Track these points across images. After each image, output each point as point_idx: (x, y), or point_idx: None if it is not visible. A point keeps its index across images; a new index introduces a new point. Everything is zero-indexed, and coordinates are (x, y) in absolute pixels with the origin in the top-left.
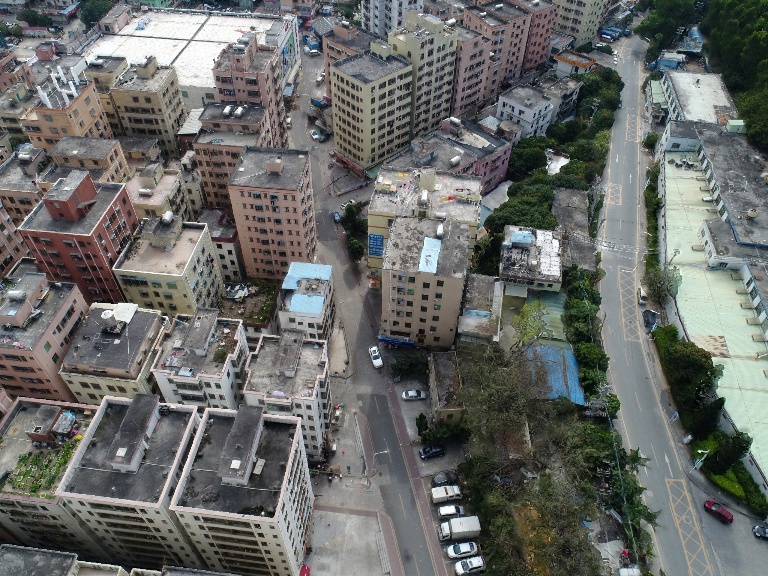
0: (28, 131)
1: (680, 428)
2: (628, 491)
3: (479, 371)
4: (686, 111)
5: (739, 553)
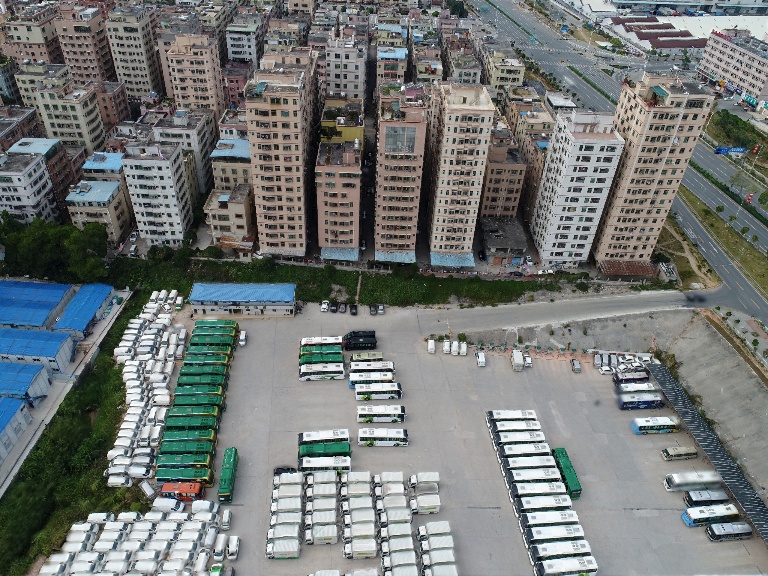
0: (3, 30)
1: None
2: None
3: (169, 2)
4: None
5: None
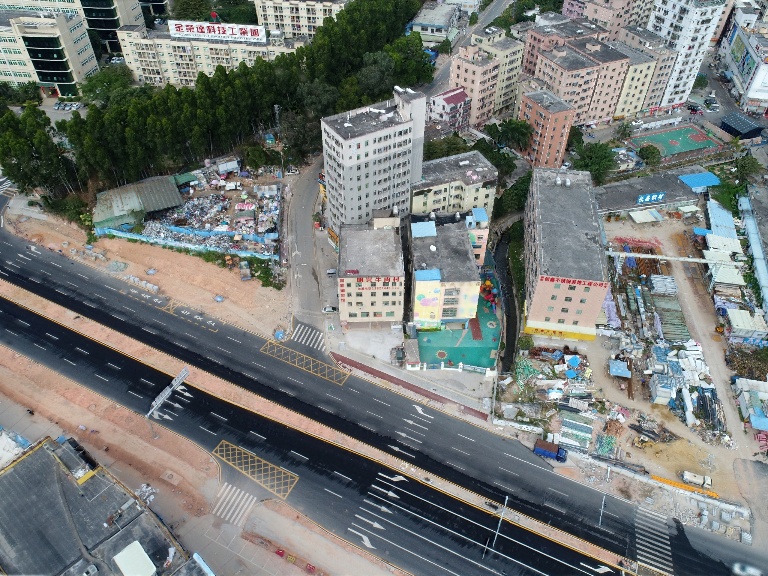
0: None
1: None
2: None
3: None
4: (454, 8)
5: None
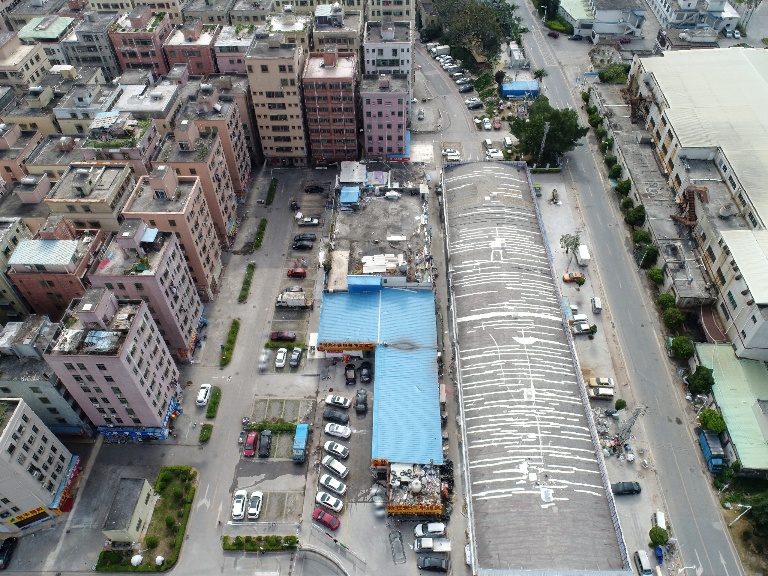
0: None
1: (540, 19)
2: (511, 22)
3: None
4: None
5: (561, 43)
